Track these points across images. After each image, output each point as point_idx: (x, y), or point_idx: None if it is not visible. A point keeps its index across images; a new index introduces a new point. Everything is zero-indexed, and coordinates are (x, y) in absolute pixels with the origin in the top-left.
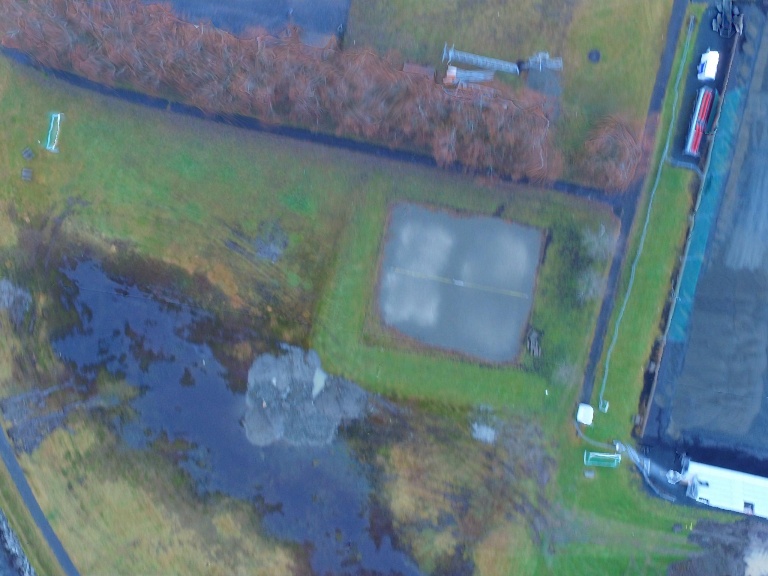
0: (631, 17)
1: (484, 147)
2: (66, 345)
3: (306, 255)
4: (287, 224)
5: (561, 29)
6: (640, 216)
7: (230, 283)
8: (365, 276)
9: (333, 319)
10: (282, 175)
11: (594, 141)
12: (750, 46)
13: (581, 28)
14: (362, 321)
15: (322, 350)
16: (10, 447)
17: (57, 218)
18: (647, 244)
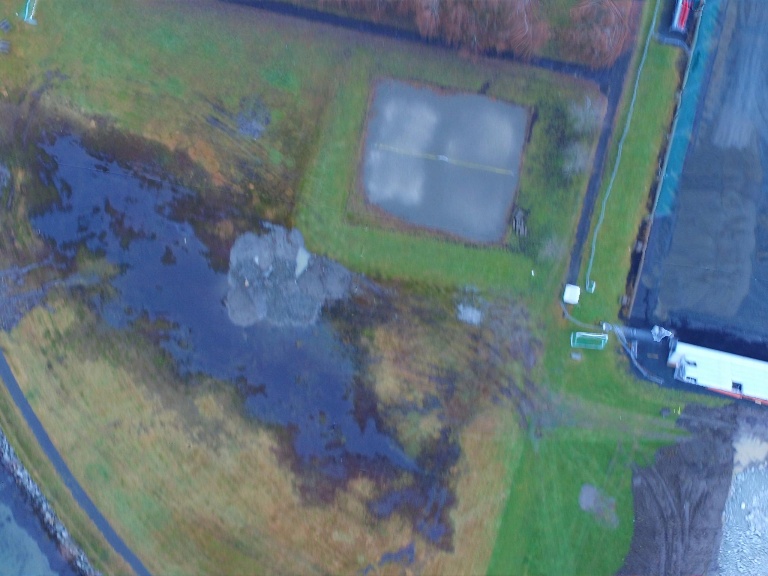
0: None
1: (468, 13)
2: (45, 222)
3: (289, 132)
4: (269, 100)
5: None
6: (627, 94)
7: (211, 160)
8: (348, 153)
9: (316, 197)
10: (264, 50)
11: (579, 7)
12: None
13: None
14: (346, 199)
15: (305, 229)
16: None
17: (35, 92)
18: (634, 122)
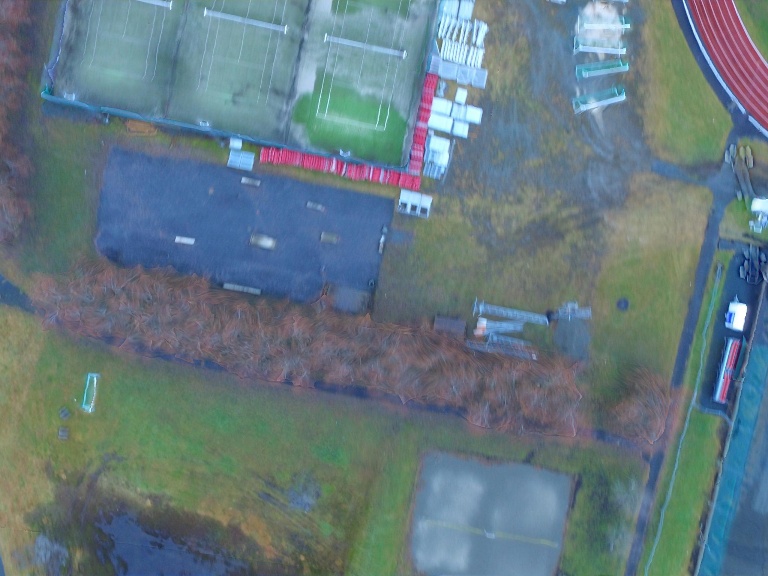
0: (659, 265)
1: (516, 415)
2: None
3: (338, 505)
4: (320, 475)
5: (590, 279)
6: (669, 461)
7: (263, 534)
8: (397, 525)
9: (365, 568)
10: (315, 427)
11: (625, 408)
12: None
13: (610, 277)
14: (394, 569)
15: None
16: None
17: (93, 474)
18: (676, 488)
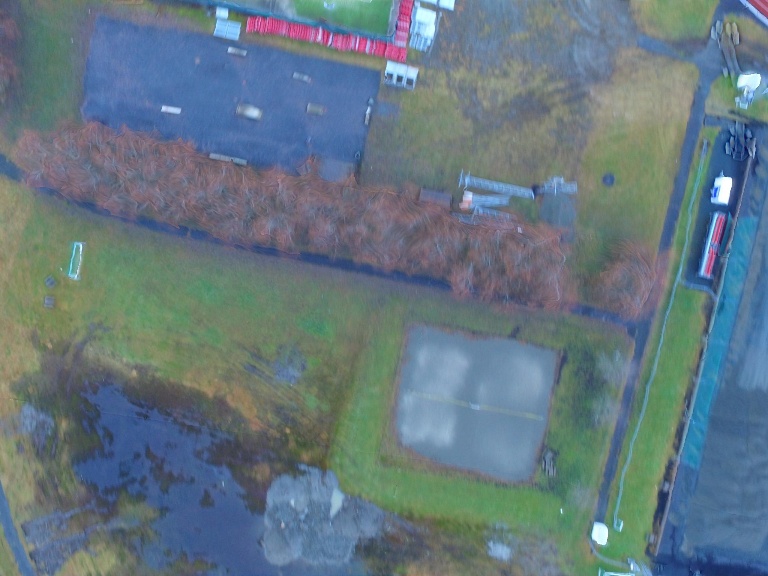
0: (645, 141)
1: (501, 279)
2: (87, 468)
3: (324, 377)
4: (305, 347)
5: (576, 154)
6: (654, 337)
7: (249, 406)
8: (382, 398)
9: (351, 441)
10: (300, 299)
11: (609, 273)
12: (763, 169)
13: (595, 152)
14: (379, 442)
15: (340, 471)
16: (32, 569)
17: (79, 344)
18: (661, 365)
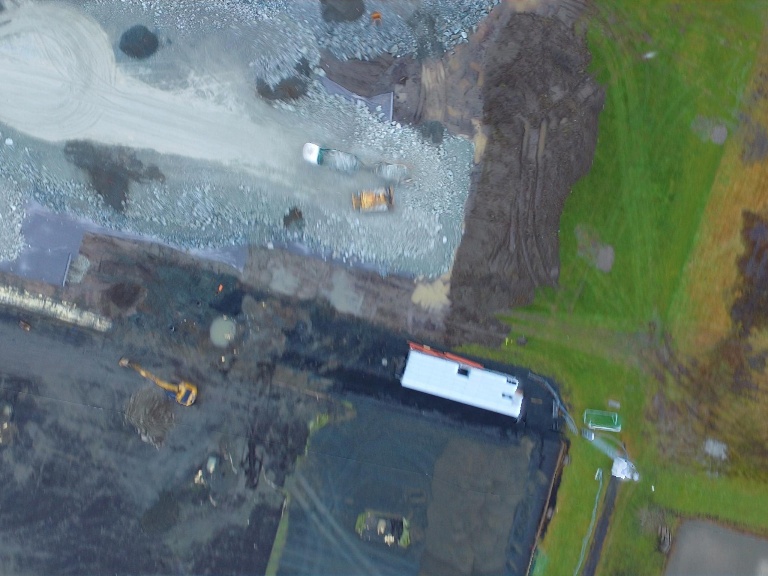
0: None
1: None
2: None
3: None
4: None
5: None
6: None
7: None
8: None
9: None
10: None
11: None
12: None
13: None
14: None
15: None
16: None
17: None
18: None
